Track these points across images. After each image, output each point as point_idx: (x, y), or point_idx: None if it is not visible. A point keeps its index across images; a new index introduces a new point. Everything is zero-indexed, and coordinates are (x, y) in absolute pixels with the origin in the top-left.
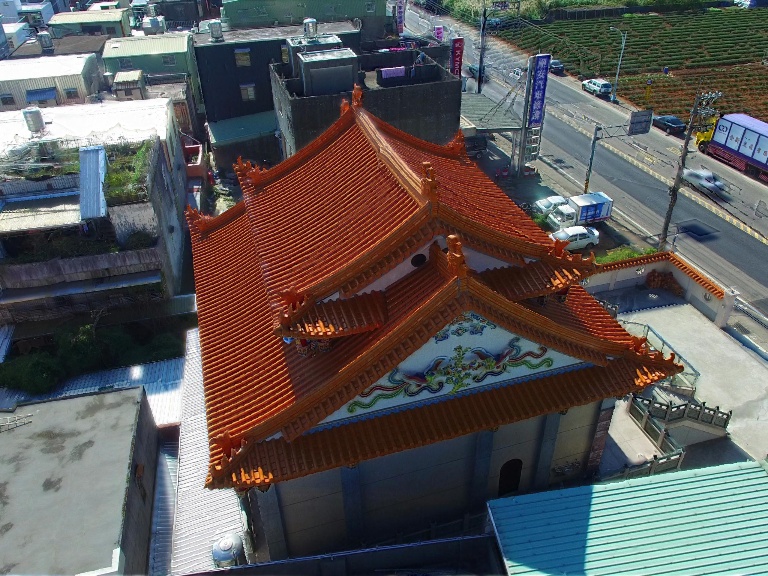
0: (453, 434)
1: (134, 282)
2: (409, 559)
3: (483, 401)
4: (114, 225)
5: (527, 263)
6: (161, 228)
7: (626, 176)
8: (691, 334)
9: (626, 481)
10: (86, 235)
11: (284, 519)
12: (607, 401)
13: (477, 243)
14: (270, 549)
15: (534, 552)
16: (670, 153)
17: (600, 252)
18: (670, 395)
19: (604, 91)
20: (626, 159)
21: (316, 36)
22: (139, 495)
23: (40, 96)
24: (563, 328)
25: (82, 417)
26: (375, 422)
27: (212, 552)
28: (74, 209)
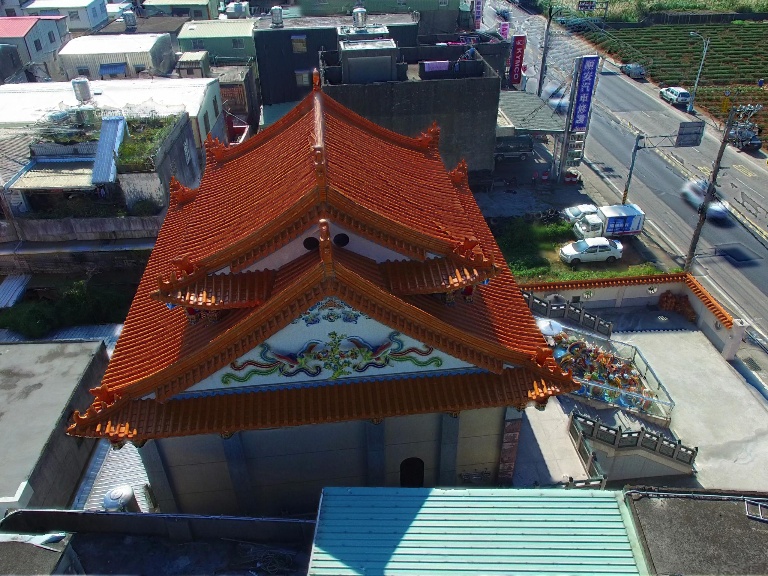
0: (321, 419)
1: (136, 246)
2: (254, 533)
3: (362, 391)
4: (124, 191)
5: (432, 259)
6: (168, 198)
7: (676, 191)
8: (691, 363)
9: (467, 490)
10: (106, 199)
11: (172, 479)
12: (511, 411)
13: (369, 232)
14: (160, 506)
15: (344, 543)
16: (735, 171)
17: (621, 267)
18: (635, 421)
19: (681, 100)
20: (683, 173)
21: (365, 26)
22: (72, 439)
23: (111, 70)
24: (450, 328)
25: (41, 361)
26: (249, 397)
27: (104, 499)
28: (91, 173)
